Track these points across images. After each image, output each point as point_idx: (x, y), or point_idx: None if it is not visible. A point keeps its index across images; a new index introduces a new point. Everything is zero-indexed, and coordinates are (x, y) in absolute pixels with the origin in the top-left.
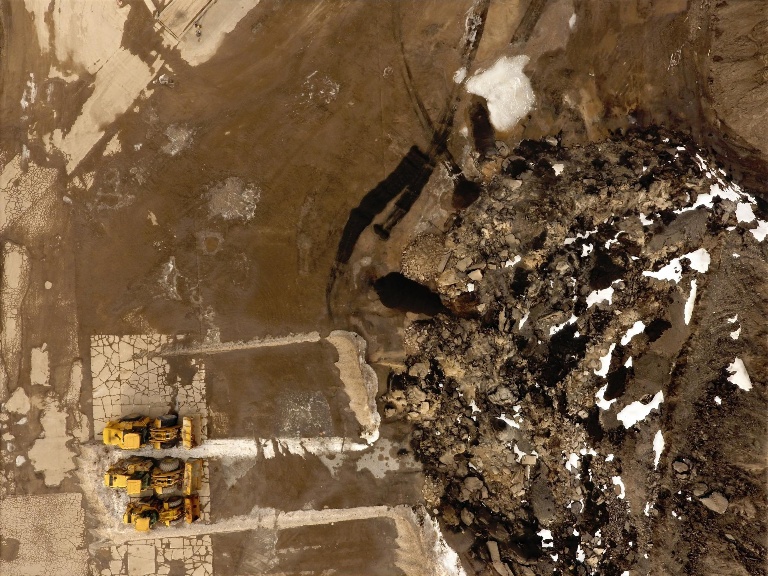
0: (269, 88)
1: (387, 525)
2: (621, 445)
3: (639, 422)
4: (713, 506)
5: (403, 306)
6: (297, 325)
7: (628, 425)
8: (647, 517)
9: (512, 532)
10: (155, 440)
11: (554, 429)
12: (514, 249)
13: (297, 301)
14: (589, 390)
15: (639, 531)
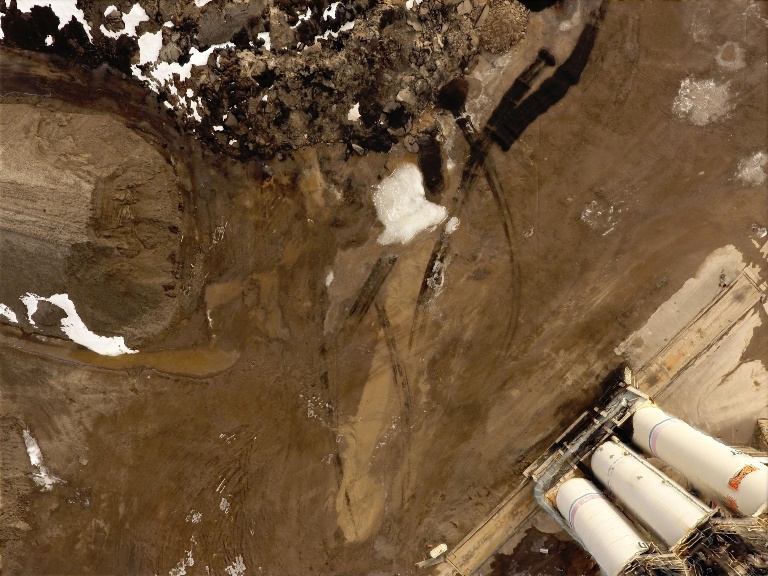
0: (654, 219)
1: None
2: None
3: None
4: None
5: None
6: None
7: None
8: None
9: None
10: None
11: None
12: (413, 16)
13: None
14: None
15: None
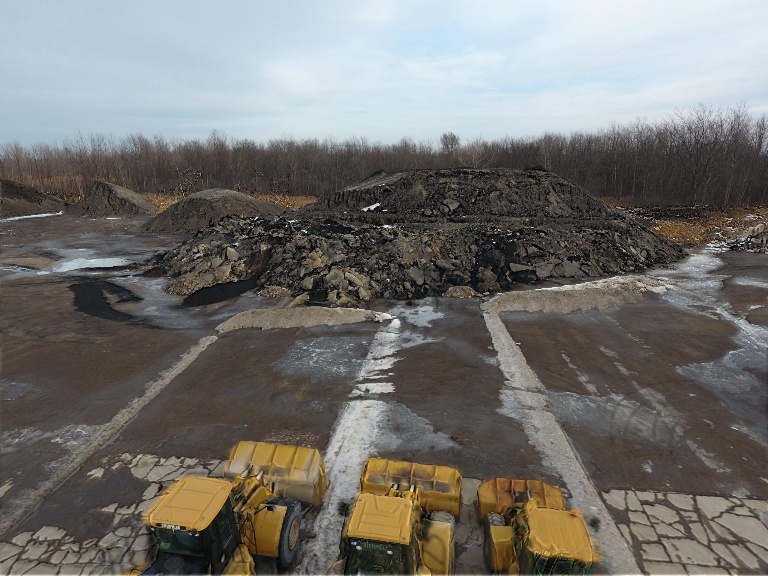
0: None
1: (511, 315)
2: None
3: None
4: (454, 205)
5: (229, 292)
6: (174, 350)
7: None
8: None
9: None
10: (243, 500)
11: None
12: None
13: (137, 348)
14: None
15: None
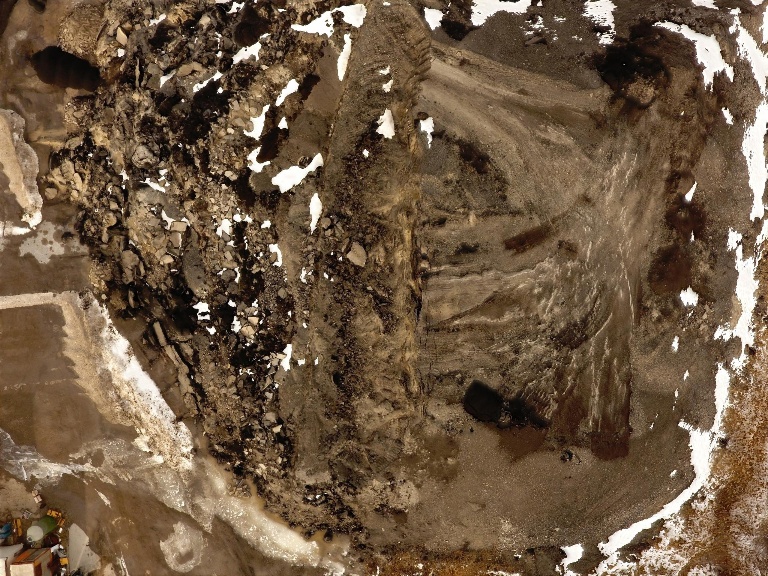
0: None
1: (54, 313)
2: (276, 210)
3: (296, 186)
4: (356, 259)
5: (59, 79)
6: None
7: (284, 189)
8: (303, 284)
9: (167, 306)
10: None
11: (198, 190)
12: (159, 7)
13: None
14: (237, 150)
15: (295, 298)
